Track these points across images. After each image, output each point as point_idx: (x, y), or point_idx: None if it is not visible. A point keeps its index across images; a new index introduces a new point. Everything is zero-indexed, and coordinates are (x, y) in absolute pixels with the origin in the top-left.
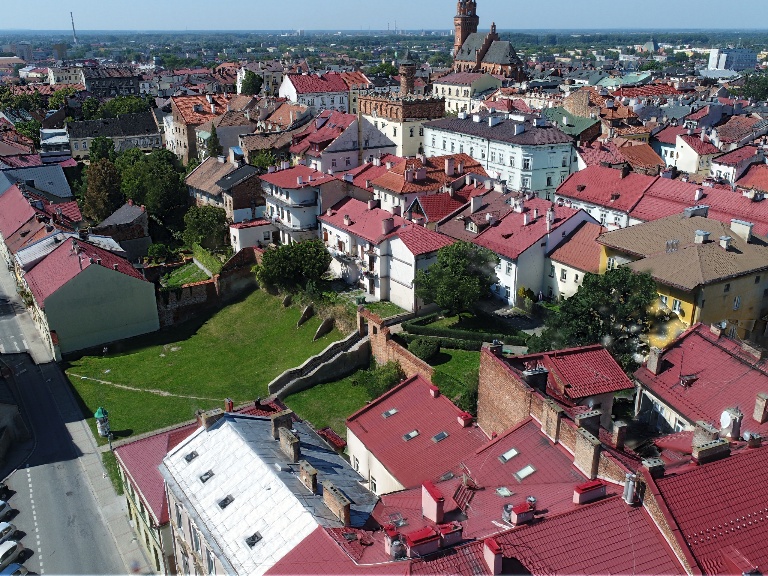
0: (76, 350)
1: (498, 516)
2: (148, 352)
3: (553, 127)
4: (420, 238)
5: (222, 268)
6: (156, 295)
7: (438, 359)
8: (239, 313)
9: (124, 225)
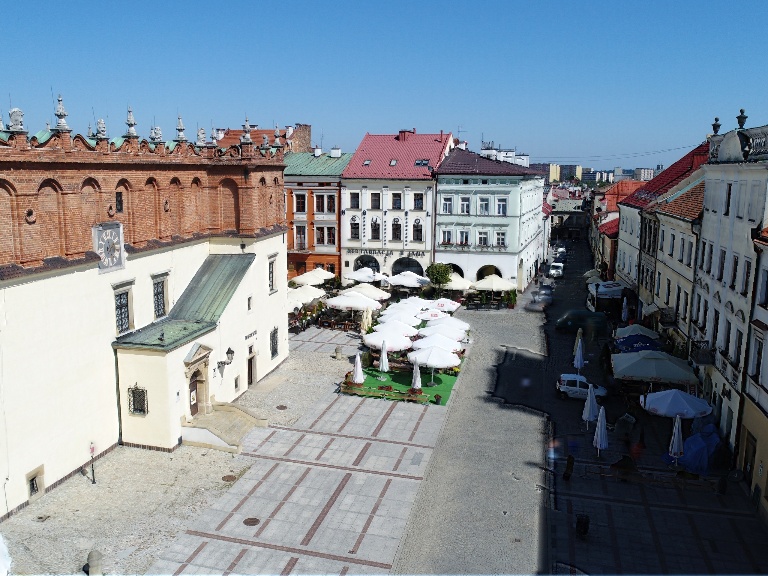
0: None
1: None
2: None
3: None
4: None
5: None
6: None
7: None
8: None
9: None
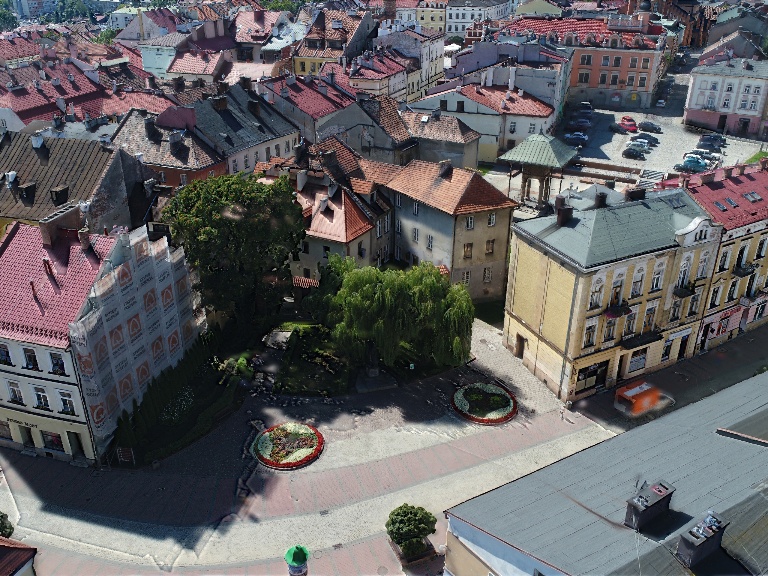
0: None
1: None
2: None
3: (190, 33)
4: None
5: None
6: None
7: None
8: None
9: None
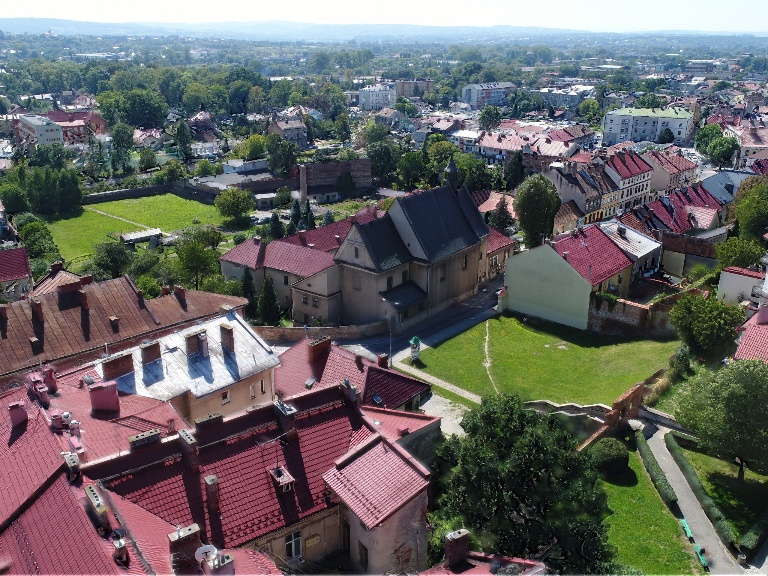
0: (518, 311)
1: (85, 425)
2: (545, 338)
3: None
4: None
5: (662, 299)
6: (591, 296)
7: (617, 477)
8: (642, 349)
9: (698, 239)
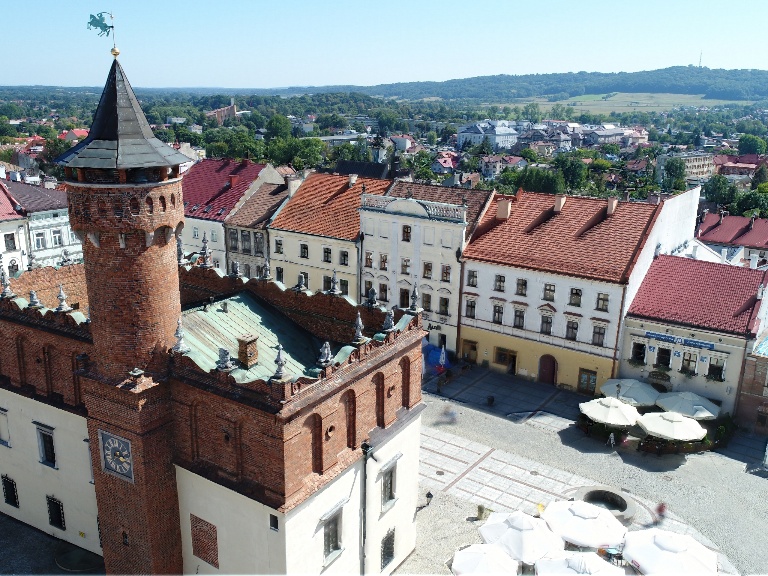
0: None
1: None
2: None
3: None
4: None
5: None
6: None
7: None
8: None
9: None
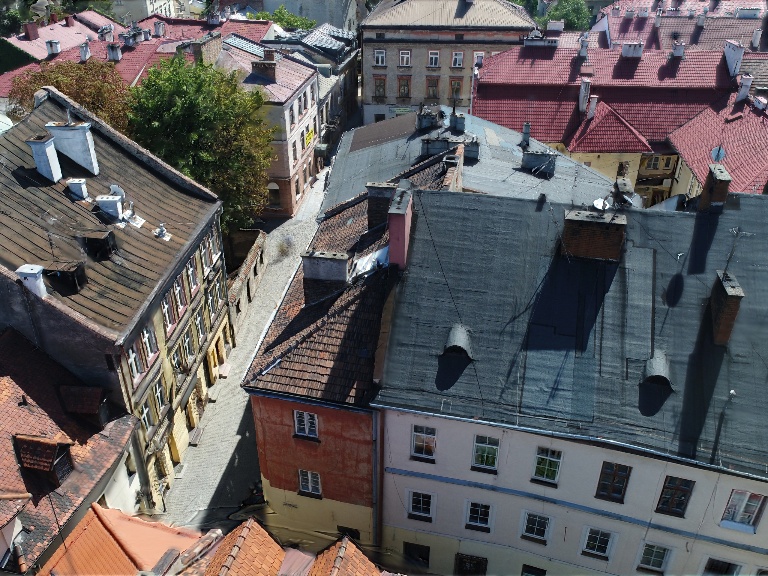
0: None
1: None
2: None
3: None
4: (622, 4)
5: None
6: None
7: None
8: None
9: None
